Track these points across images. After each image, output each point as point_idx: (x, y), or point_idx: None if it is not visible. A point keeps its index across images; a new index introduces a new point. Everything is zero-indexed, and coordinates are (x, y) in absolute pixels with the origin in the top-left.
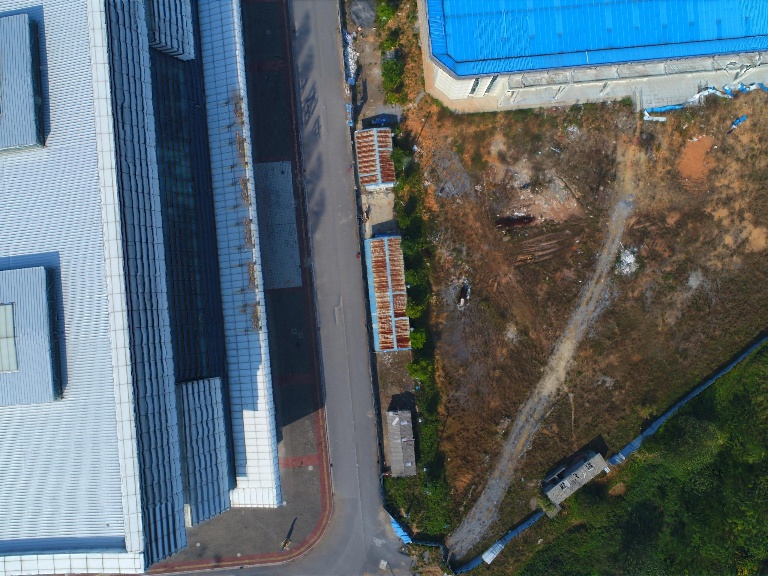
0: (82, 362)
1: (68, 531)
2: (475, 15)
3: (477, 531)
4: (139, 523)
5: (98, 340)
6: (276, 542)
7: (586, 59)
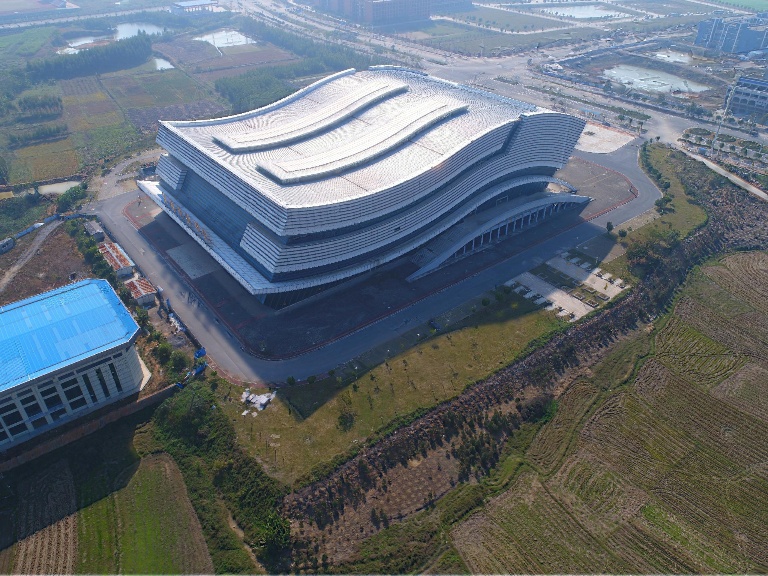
0: None
1: None
2: None
3: (48, 227)
4: None
5: None
6: None
7: (3, 309)
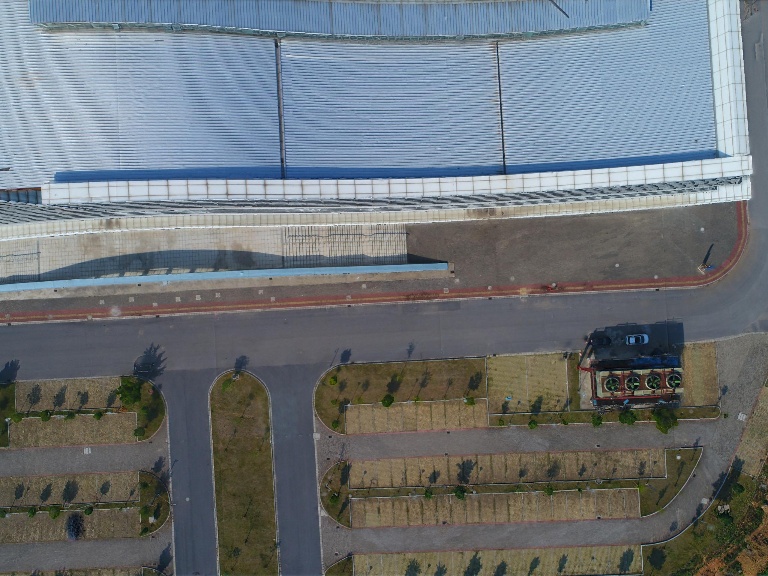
0: None
1: (650, 150)
2: None
3: None
4: (745, 128)
5: None
6: (693, 266)
7: None
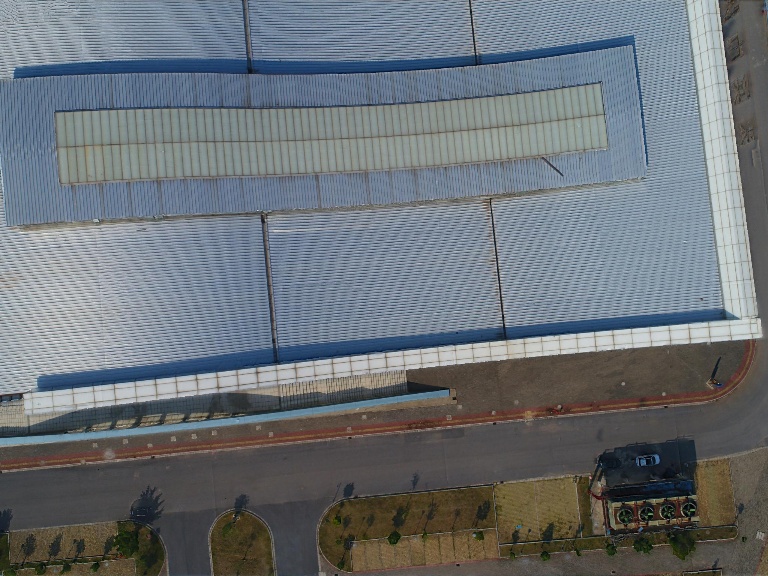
0: (665, 142)
1: (654, 308)
2: None
3: None
4: (752, 289)
5: (683, 119)
6: (701, 381)
7: None
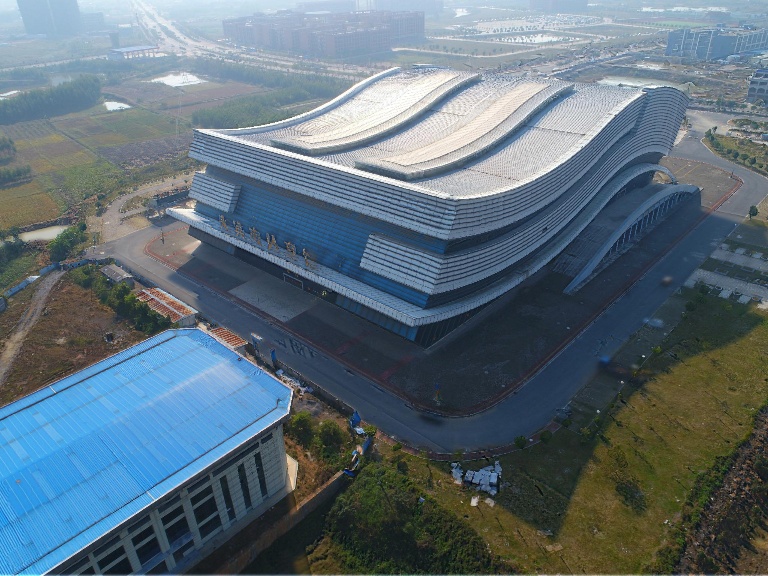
0: None
1: None
2: (178, 358)
3: None
4: None
5: None
6: None
7: (54, 388)
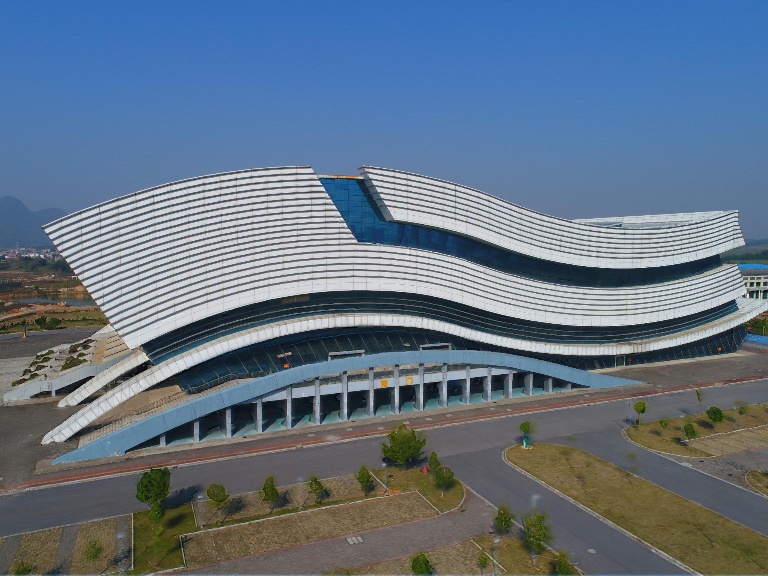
0: None
1: None
2: None
3: None
4: None
5: None
6: None
7: None
